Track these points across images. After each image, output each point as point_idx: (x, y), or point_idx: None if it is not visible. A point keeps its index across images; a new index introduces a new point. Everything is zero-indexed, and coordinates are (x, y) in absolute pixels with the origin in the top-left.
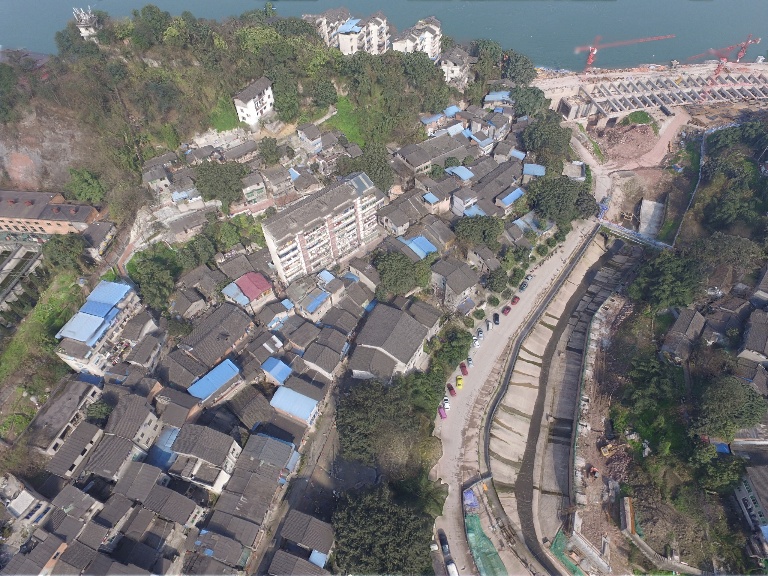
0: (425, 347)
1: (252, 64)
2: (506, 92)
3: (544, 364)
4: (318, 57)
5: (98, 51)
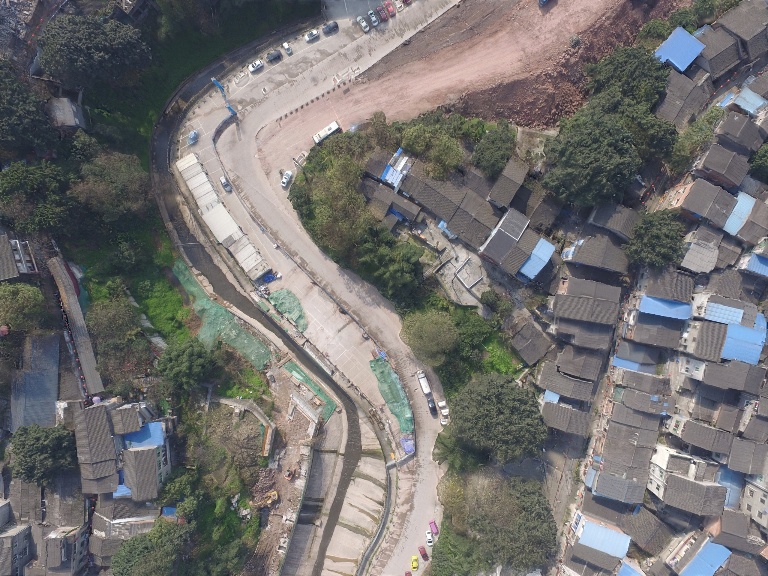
0: None
1: None
2: None
3: None
4: None
5: None
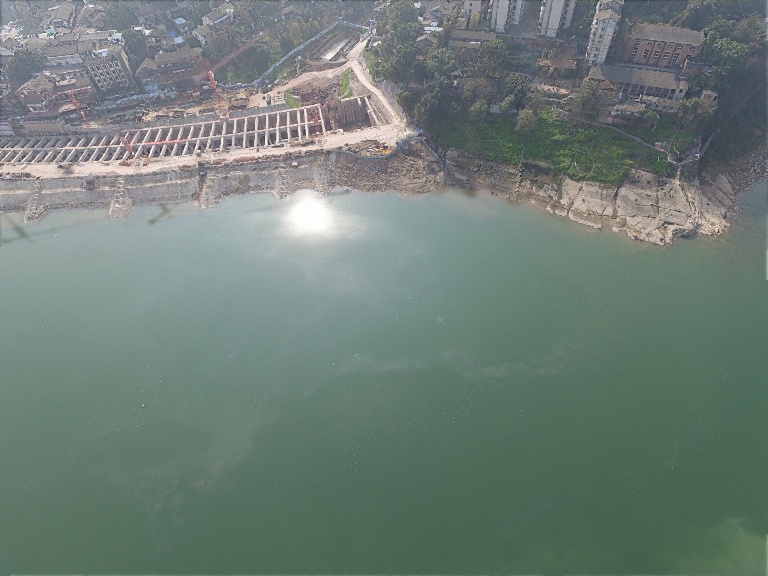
0: None
1: None
2: None
3: None
4: None
5: None
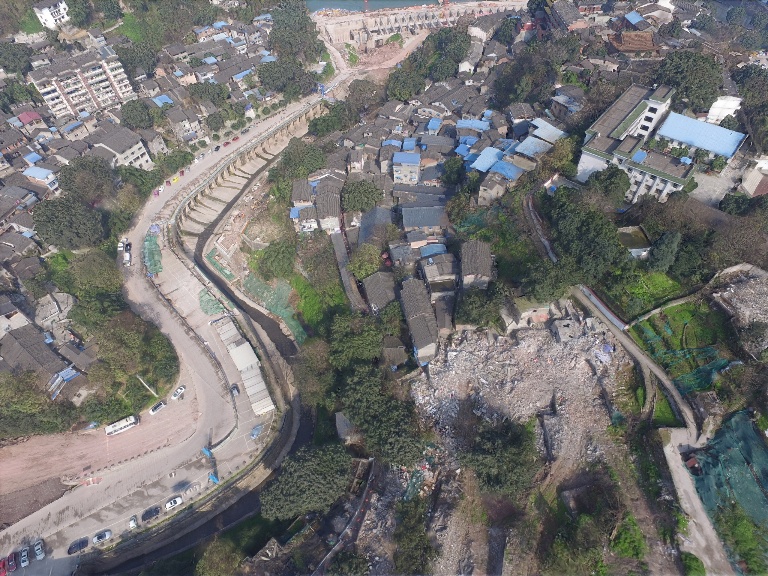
0: (157, 161)
1: None
2: None
3: (251, 178)
4: None
5: None
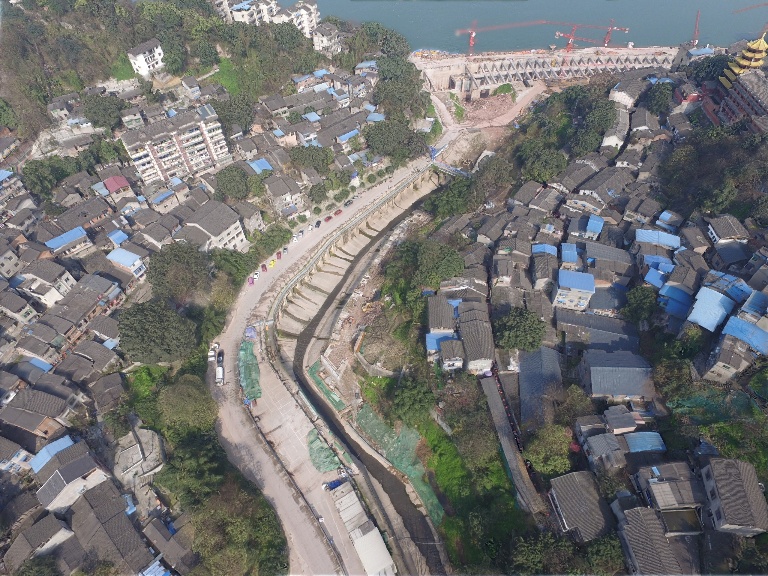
0: (251, 239)
1: (146, 28)
2: (375, 61)
3: (354, 261)
4: (201, 24)
5: (23, 15)
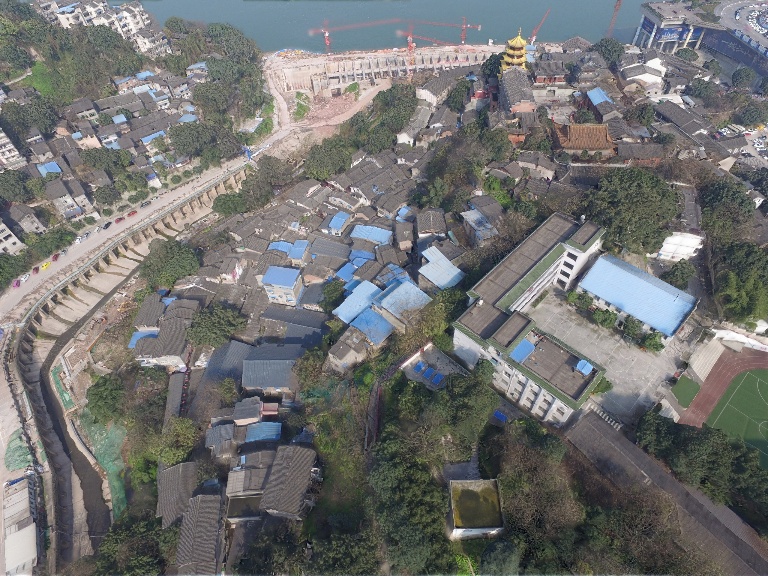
0: (30, 241)
1: None
2: None
3: (144, 261)
4: (7, 28)
5: None
